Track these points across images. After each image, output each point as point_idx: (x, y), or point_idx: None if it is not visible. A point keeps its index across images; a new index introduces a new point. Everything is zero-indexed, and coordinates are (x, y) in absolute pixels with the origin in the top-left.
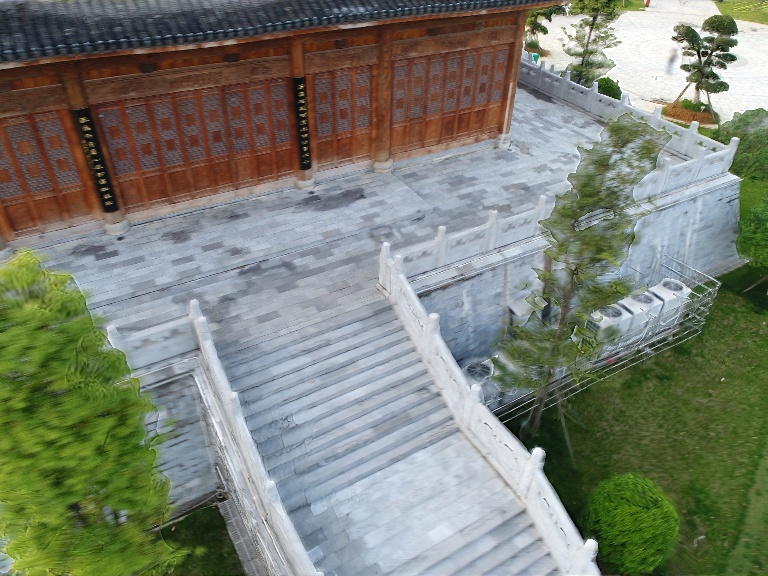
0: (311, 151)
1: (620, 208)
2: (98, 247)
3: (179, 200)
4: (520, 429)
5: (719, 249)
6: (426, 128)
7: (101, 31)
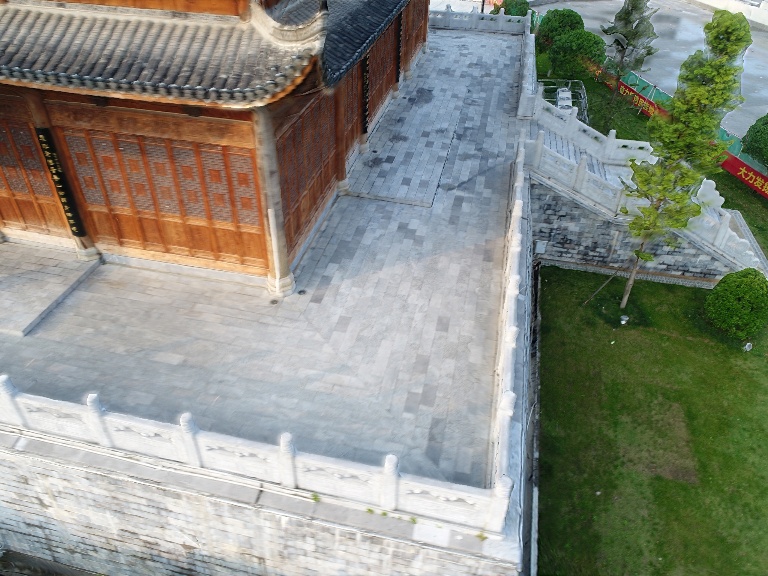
0: None
1: (642, 14)
2: (375, 159)
3: (372, 119)
4: None
5: None
6: (412, 43)
7: None
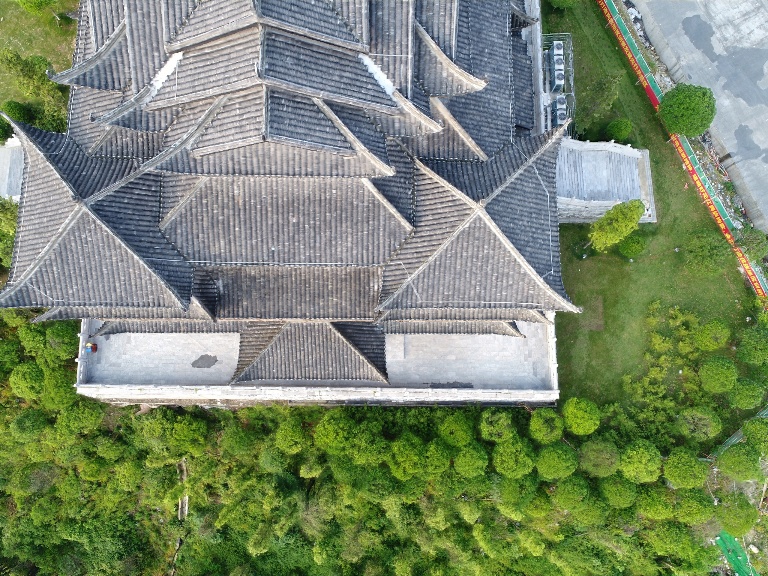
0: None
1: None
2: None
3: None
4: (580, 135)
5: None
6: None
7: None
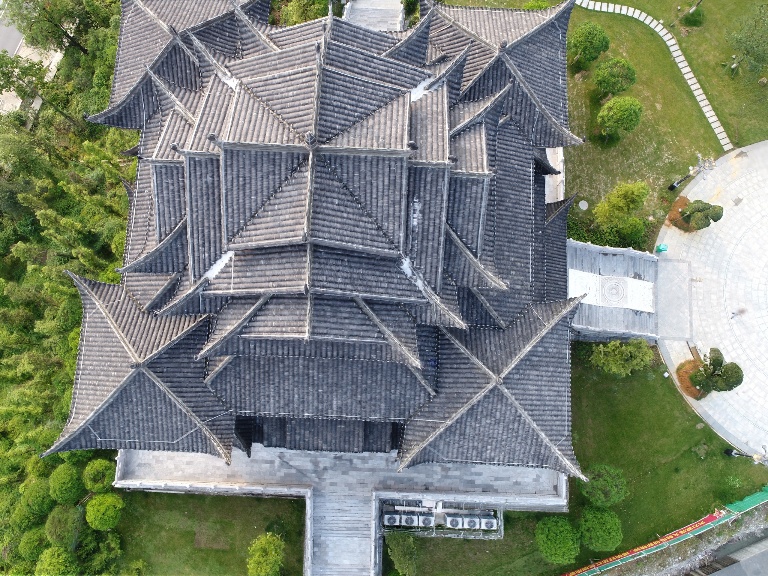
0: None
1: None
2: None
3: None
4: None
5: None
6: None
7: None
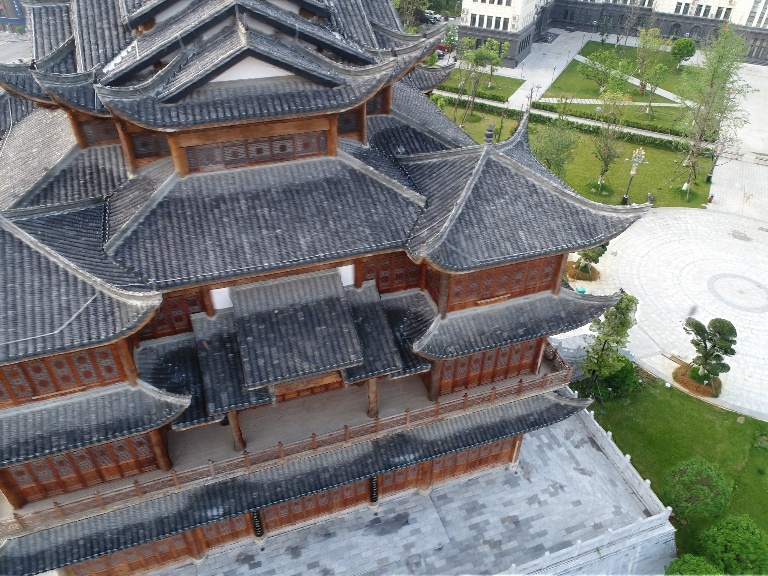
0: (378, 492)
1: None
2: (250, 556)
3: (297, 523)
4: None
5: (659, 568)
6: (456, 468)
7: (270, 492)
